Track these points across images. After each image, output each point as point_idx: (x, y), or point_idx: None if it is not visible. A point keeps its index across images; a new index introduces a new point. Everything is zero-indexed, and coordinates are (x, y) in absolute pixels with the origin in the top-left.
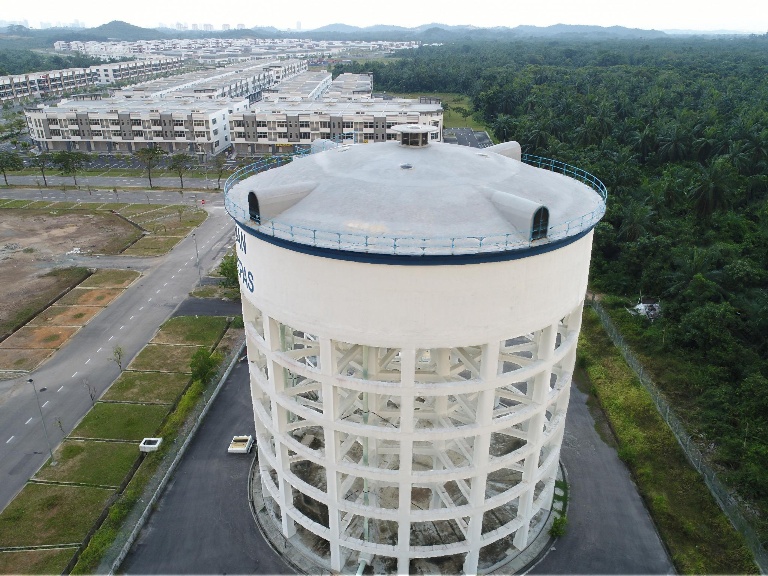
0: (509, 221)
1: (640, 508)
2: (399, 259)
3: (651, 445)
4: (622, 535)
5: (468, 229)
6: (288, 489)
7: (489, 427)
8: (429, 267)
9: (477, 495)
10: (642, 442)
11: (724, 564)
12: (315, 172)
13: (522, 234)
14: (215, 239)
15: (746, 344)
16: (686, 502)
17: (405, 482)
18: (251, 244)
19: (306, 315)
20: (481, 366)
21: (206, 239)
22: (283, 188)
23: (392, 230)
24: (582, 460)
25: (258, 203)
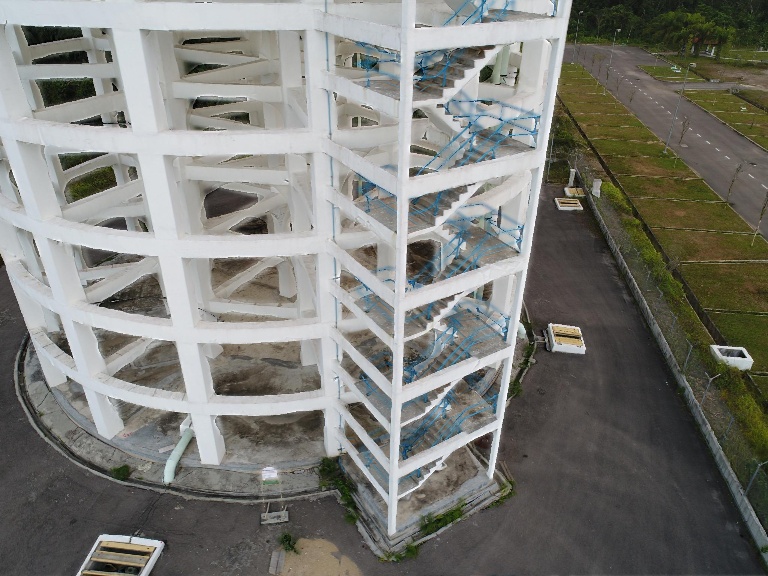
0: None
1: None
2: None
3: None
4: None
5: None
6: None
7: None
8: None
9: None
10: None
11: None
12: None
13: None
14: None
15: None
16: None
17: None
18: None
19: None
20: None
21: None
22: None
23: None
24: (16, 301)
25: None
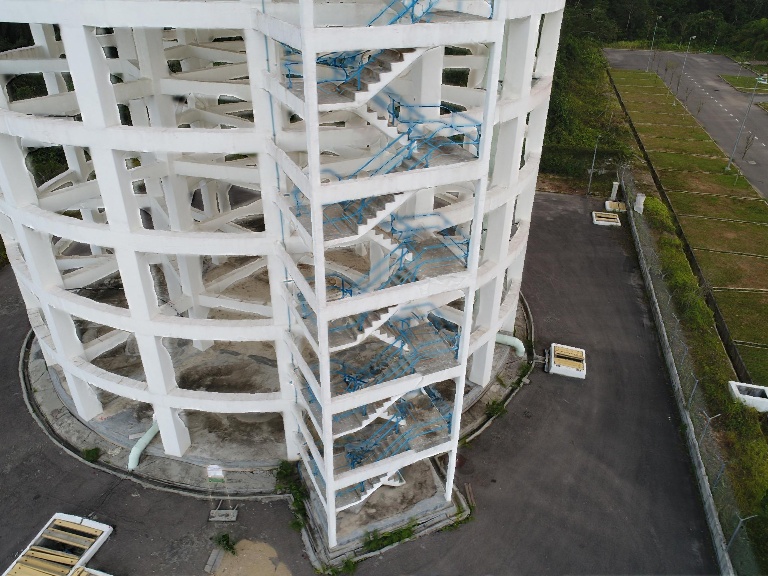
0: None
1: None
2: None
3: None
4: None
5: None
6: None
7: None
8: None
9: None
10: None
11: None
12: None
13: None
14: None
15: None
16: None
17: None
18: None
19: None
20: None
21: None
22: None
23: None
24: None
25: None
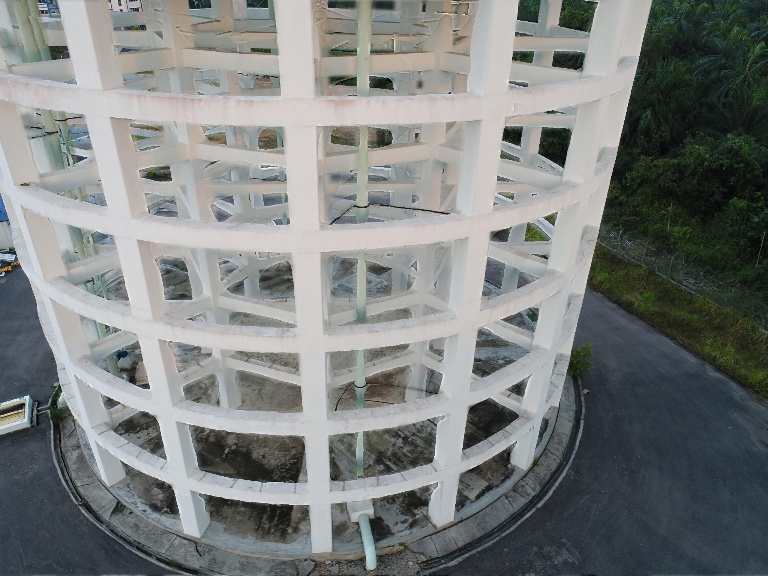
0: None
1: (626, 316)
2: None
3: None
4: (635, 349)
5: None
6: (187, 442)
7: (590, 184)
8: None
9: (556, 324)
10: None
11: None
12: None
13: None
14: None
15: None
16: None
17: (468, 329)
18: None
19: None
20: (591, 47)
21: None
22: None
23: None
24: None
25: None
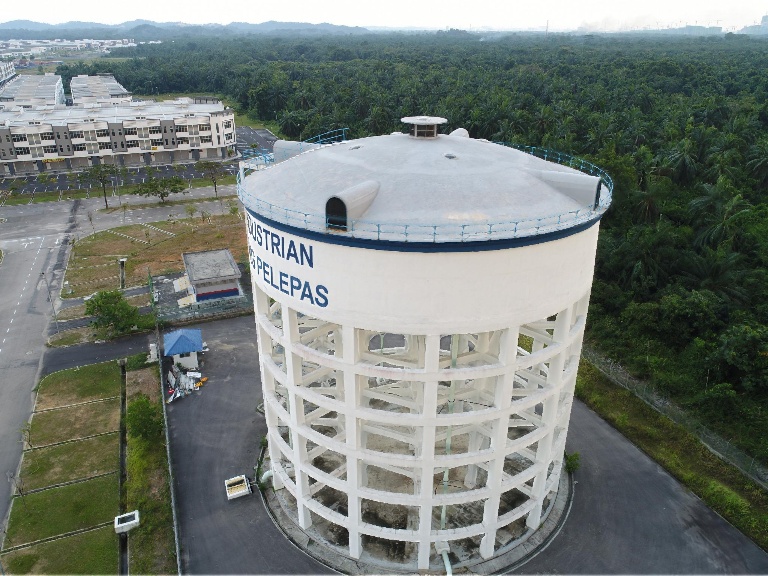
0: (568, 195)
1: (610, 429)
2: (516, 242)
3: (584, 378)
4: (612, 454)
5: (548, 206)
6: (359, 507)
7: (560, 385)
8: (537, 245)
9: (547, 450)
10: (579, 377)
11: (683, 451)
12: (359, 171)
13: (585, 205)
14: (33, 277)
15: (604, 282)
16: (632, 414)
17: (500, 457)
18: (327, 254)
19: (412, 316)
20: (555, 331)
21: (21, 279)
22: (358, 190)
23: (493, 216)
24: None
25: (346, 208)
